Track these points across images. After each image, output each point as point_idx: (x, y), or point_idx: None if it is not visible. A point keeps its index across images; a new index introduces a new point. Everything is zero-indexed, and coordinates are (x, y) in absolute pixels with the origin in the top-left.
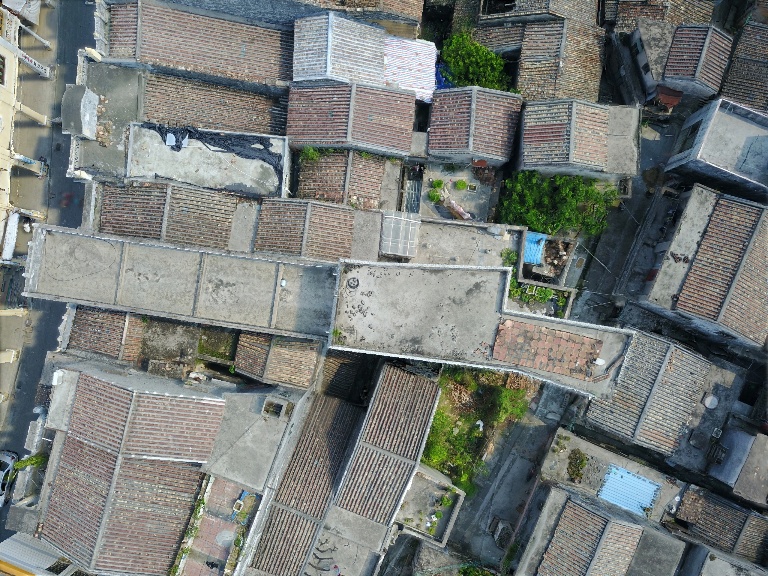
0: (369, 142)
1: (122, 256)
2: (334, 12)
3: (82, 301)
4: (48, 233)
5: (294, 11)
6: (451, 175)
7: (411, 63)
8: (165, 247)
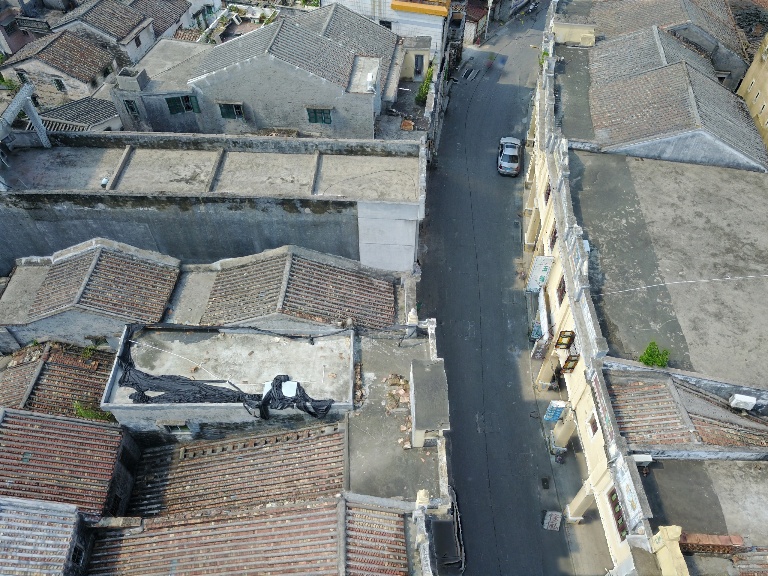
0: None
1: None
2: None
3: (353, 141)
4: None
5: None
6: None
7: None
8: None
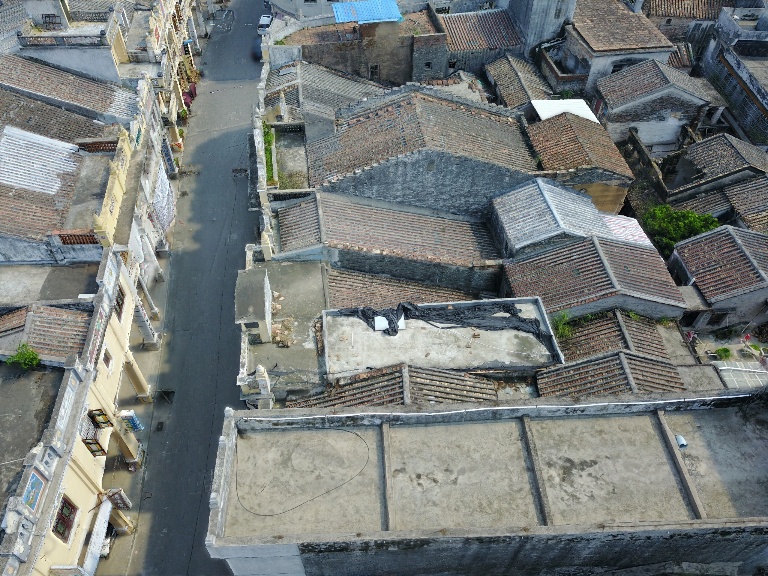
0: (640, 292)
1: (384, 446)
2: (541, 179)
3: (330, 534)
4: (239, 436)
5: (494, 187)
6: (729, 343)
7: (625, 233)
8: (452, 422)
